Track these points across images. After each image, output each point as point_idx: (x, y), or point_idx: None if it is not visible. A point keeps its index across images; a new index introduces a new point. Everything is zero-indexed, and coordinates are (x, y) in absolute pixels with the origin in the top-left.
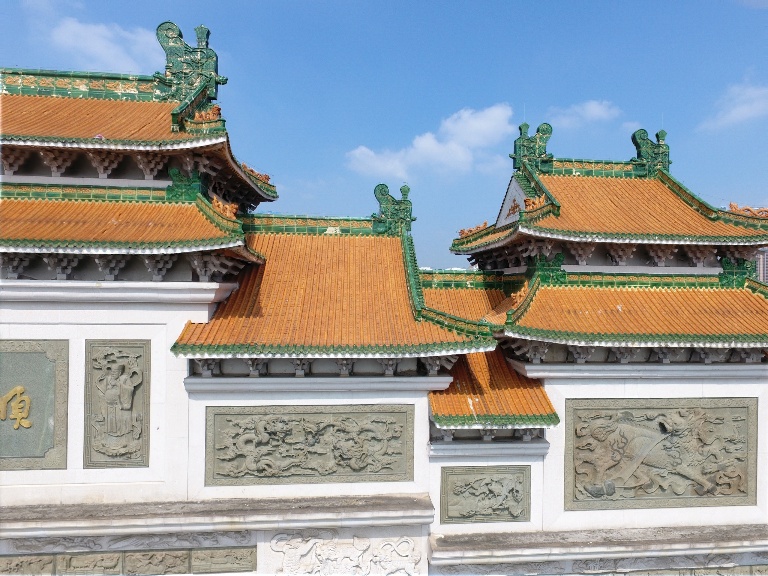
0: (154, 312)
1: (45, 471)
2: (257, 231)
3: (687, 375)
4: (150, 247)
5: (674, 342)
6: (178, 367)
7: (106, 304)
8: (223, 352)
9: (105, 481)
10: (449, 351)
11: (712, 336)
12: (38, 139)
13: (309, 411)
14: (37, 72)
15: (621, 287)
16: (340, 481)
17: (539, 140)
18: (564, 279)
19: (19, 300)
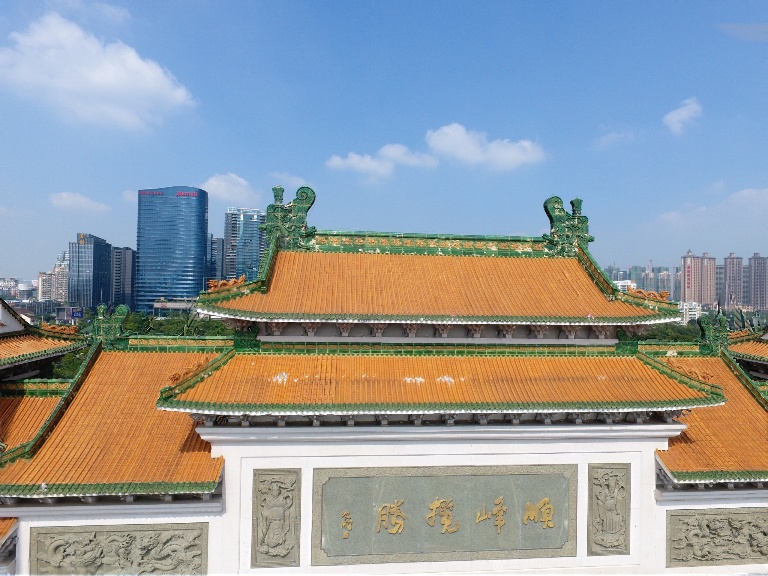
0: (634, 443)
1: (562, 558)
2: None
3: None
4: (663, 407)
5: None
6: (649, 482)
7: (605, 439)
8: (709, 479)
9: (601, 565)
10: None
11: None
12: (555, 320)
13: (733, 512)
14: (462, 237)
15: None
16: (754, 563)
17: None
18: None
19: (552, 438)
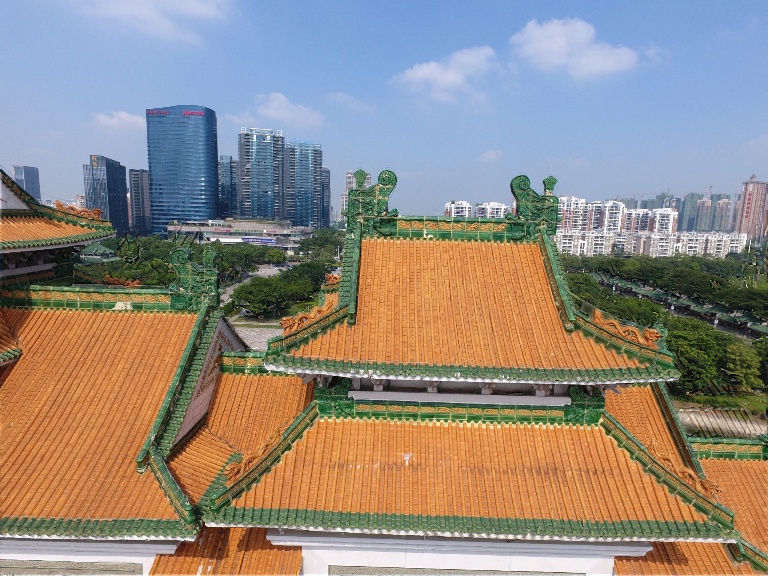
0: None
1: None
2: (34, 306)
3: (483, 550)
4: None
5: (445, 531)
6: None
7: None
8: None
9: None
10: (142, 536)
11: (503, 522)
12: None
13: (20, 565)
14: None
15: (427, 420)
16: None
17: (378, 193)
18: (351, 409)
19: None
